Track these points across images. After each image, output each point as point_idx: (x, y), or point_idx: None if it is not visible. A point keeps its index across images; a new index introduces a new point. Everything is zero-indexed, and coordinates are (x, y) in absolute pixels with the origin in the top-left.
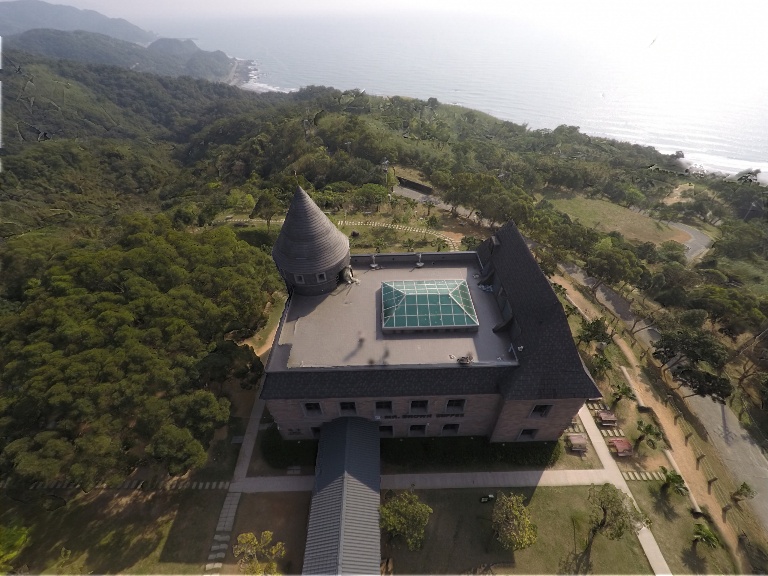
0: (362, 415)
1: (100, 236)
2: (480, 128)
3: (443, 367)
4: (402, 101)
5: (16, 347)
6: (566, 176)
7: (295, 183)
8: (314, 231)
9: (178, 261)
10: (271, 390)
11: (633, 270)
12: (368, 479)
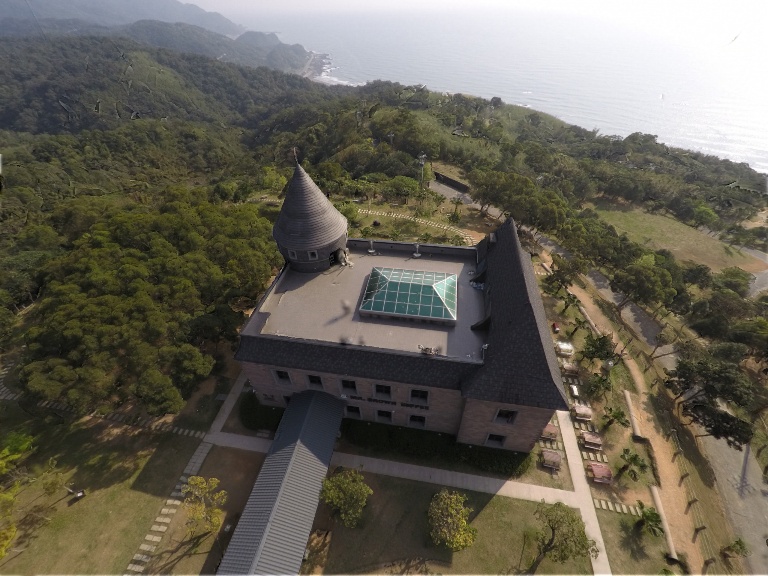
0: (329, 391)
1: (151, 203)
2: (544, 131)
3: (405, 354)
4: (462, 98)
5: (55, 286)
6: (625, 186)
7: (331, 170)
8: (309, 209)
9: (199, 229)
10: (244, 352)
11: (665, 290)
12: (320, 451)
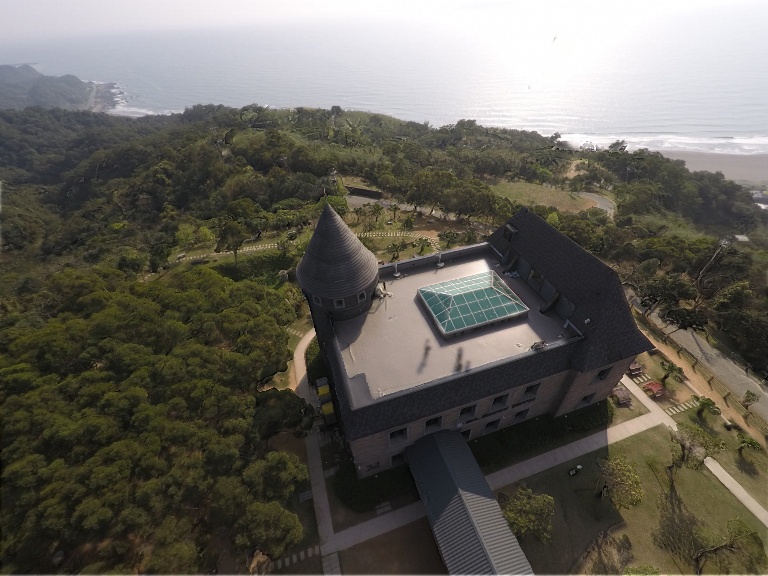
0: (445, 427)
1: None
2: (388, 131)
3: (524, 357)
4: (309, 112)
5: None
6: (488, 165)
7: (244, 207)
8: (349, 249)
9: (168, 315)
10: (359, 428)
11: (594, 236)
12: (480, 489)
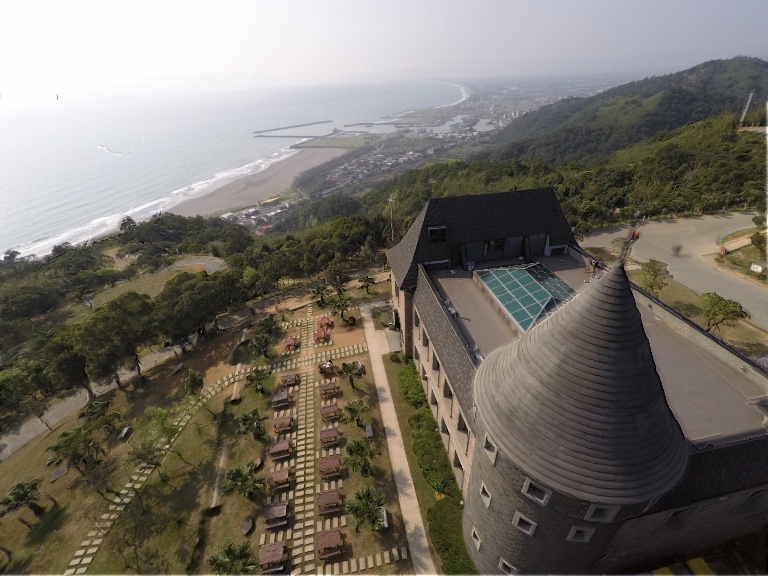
0: None
1: None
2: None
3: None
4: None
5: None
6: (31, 302)
7: None
8: None
9: None
10: None
11: None
12: None
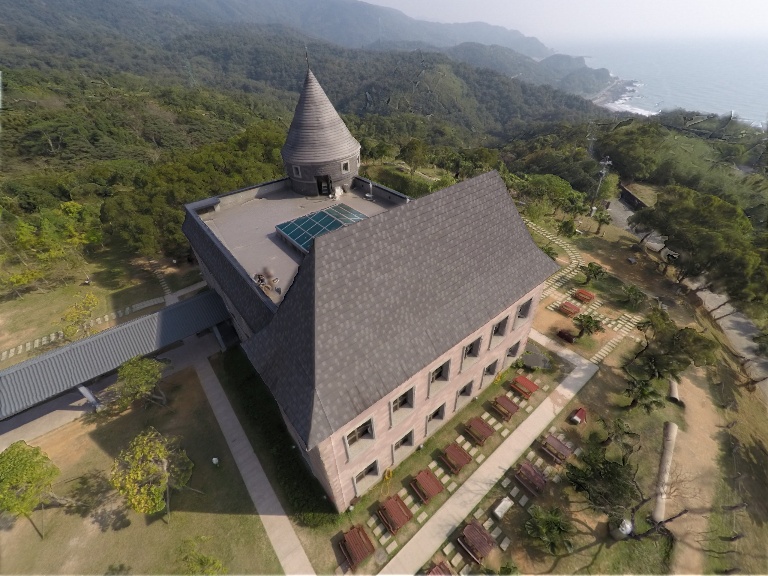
0: None
1: None
2: None
3: (238, 270)
4: None
5: None
6: None
7: (483, 155)
8: (306, 120)
9: None
10: None
11: None
12: (164, 333)
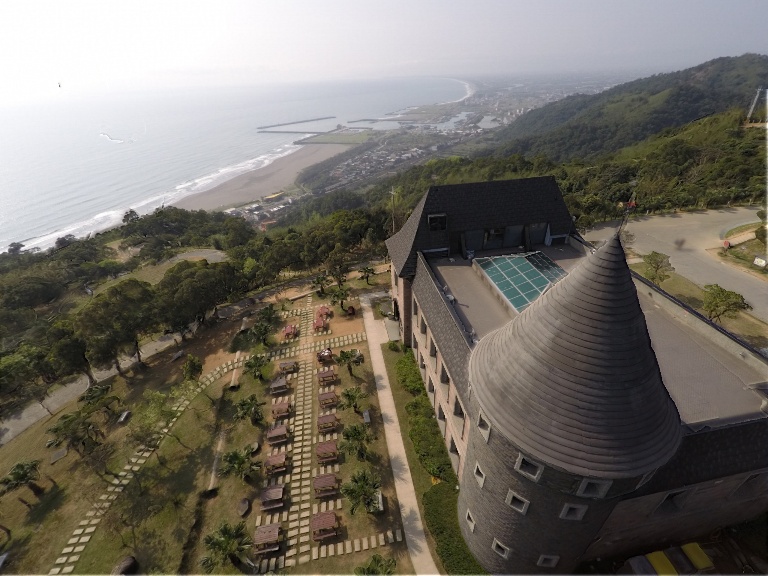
0: None
1: None
2: None
3: None
4: None
5: None
6: (34, 292)
7: None
8: None
9: None
10: None
11: None
12: None
